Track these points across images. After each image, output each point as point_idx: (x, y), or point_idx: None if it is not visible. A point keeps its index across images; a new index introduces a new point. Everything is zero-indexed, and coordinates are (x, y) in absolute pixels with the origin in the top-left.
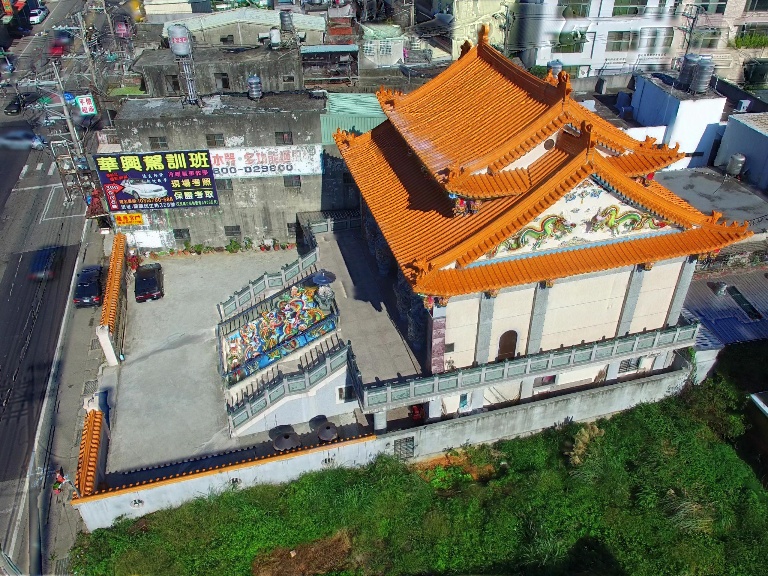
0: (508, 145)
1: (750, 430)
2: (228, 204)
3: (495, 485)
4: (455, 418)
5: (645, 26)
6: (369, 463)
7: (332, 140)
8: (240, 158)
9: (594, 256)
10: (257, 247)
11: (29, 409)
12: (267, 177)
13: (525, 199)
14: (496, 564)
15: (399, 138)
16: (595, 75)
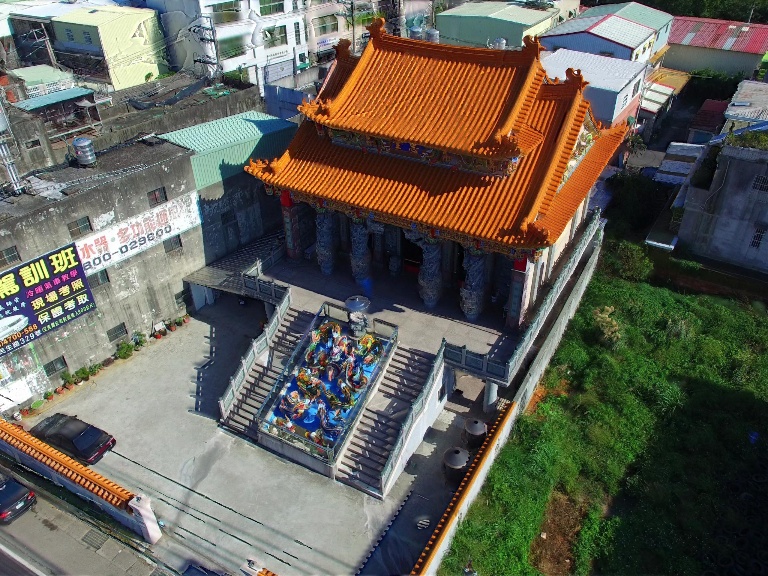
0: (518, 106)
1: (653, 265)
2: (106, 302)
3: (590, 386)
4: (537, 356)
5: (315, 17)
6: (510, 432)
7: (205, 182)
8: (113, 239)
9: (582, 176)
10: (149, 338)
11: None
12: (146, 250)
13: (559, 143)
14: (656, 429)
15: (332, 146)
16: (262, 73)
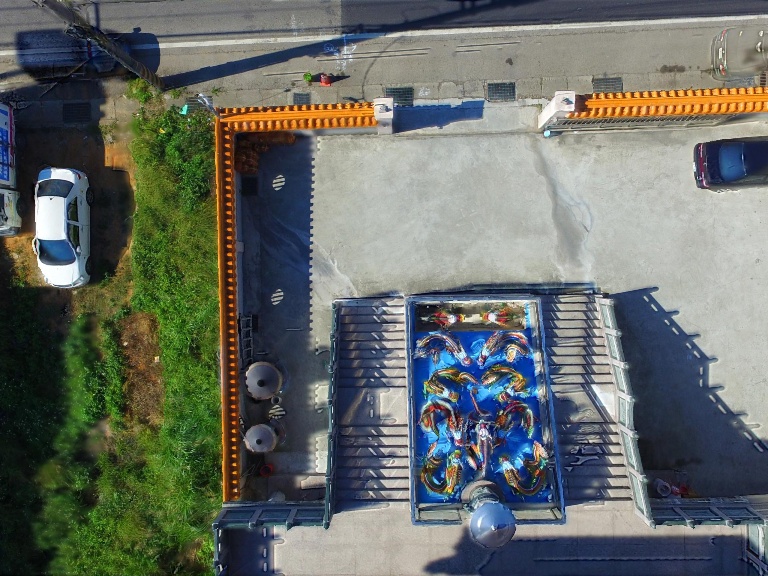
0: None
1: None
2: None
3: None
4: None
5: None
6: None
7: None
8: None
9: None
10: None
11: (473, 9)
12: None
13: None
14: None
15: None
16: None
